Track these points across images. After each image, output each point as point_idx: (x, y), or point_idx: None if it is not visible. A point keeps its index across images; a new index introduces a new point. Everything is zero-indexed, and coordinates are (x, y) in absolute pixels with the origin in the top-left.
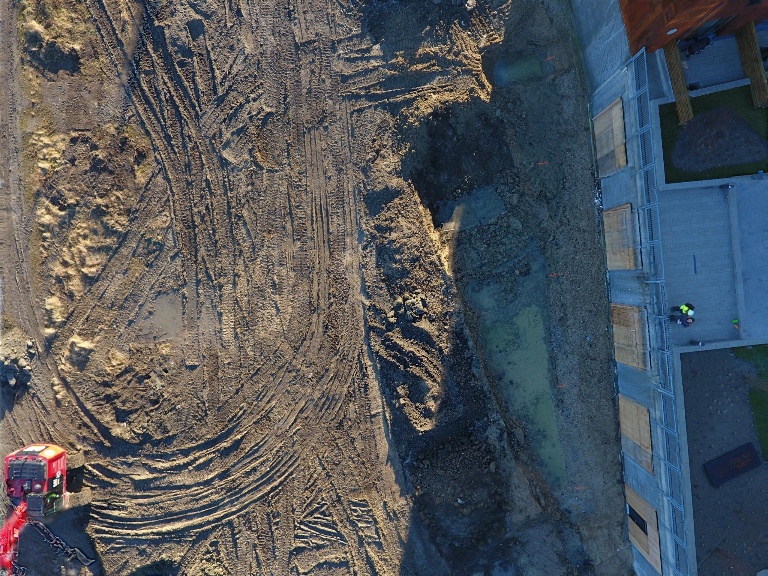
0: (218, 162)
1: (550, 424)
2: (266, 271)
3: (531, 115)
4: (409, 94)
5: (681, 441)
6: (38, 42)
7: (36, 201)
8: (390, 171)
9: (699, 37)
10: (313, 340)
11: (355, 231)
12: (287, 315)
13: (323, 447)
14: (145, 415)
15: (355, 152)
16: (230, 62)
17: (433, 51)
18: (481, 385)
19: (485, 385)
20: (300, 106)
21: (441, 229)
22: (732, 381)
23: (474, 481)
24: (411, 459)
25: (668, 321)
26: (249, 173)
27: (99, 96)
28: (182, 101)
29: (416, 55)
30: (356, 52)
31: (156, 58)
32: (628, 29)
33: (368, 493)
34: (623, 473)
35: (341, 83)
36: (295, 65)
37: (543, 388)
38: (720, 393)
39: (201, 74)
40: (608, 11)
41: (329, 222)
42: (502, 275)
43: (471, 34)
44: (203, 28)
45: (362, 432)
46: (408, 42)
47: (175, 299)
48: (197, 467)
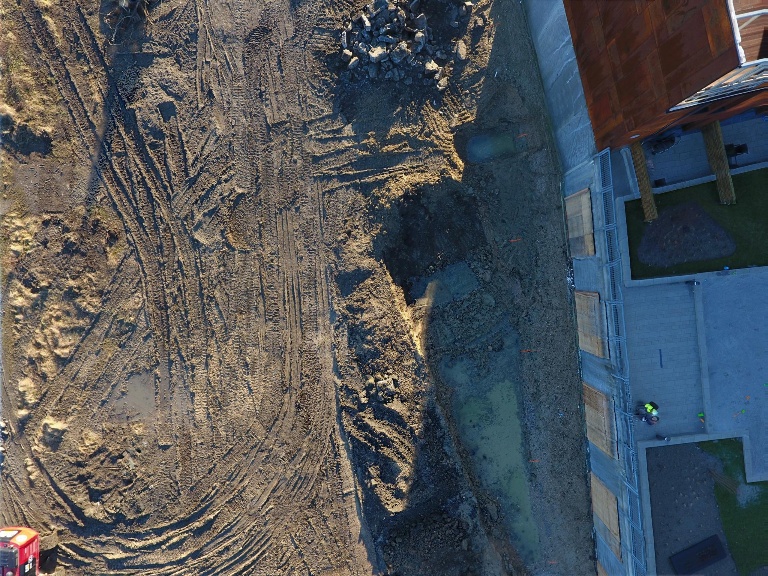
0: (190, 243)
1: (523, 498)
2: (238, 351)
3: (504, 192)
4: (381, 175)
5: (647, 535)
6: (10, 125)
7: (9, 283)
8: (361, 252)
9: (663, 140)
10: (285, 420)
11: (327, 311)
12: (259, 395)
13: (296, 526)
14: (118, 495)
15: (327, 233)
16: (202, 143)
17: (404, 132)
18: (453, 463)
19: (457, 463)
20: (272, 187)
21: (414, 305)
22: (698, 474)
23: (445, 561)
24: (383, 537)
25: (633, 419)
26: (221, 254)
27: (71, 178)
28: (154, 183)
29: (387, 136)
30: (328, 133)
31: (128, 140)
32: (594, 126)
33: (340, 571)
34: (595, 550)
35: (313, 164)
36: (267, 146)
37: (516, 462)
38: (686, 486)
39: (173, 156)
40: (575, 103)
41: (301, 302)
42: (475, 351)
43: (443, 114)
44: (174, 110)
45: (334, 511)
46: (380, 122)
47: (148, 379)
48: (170, 546)
